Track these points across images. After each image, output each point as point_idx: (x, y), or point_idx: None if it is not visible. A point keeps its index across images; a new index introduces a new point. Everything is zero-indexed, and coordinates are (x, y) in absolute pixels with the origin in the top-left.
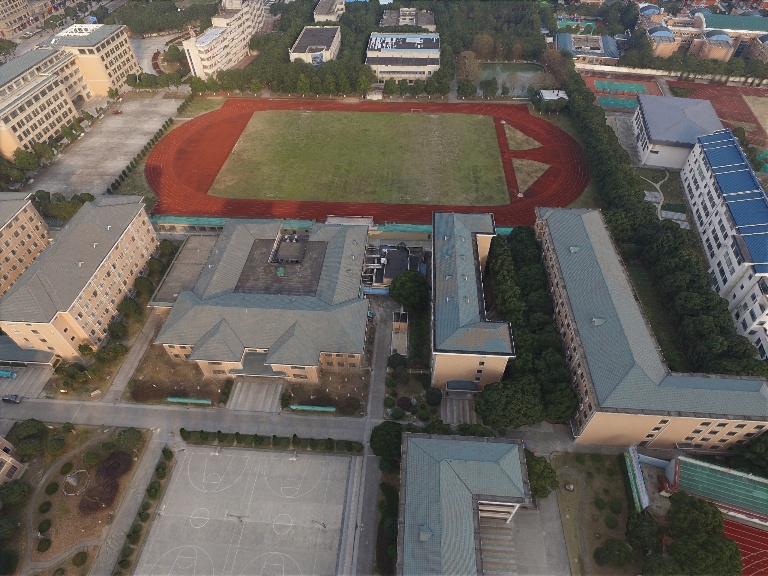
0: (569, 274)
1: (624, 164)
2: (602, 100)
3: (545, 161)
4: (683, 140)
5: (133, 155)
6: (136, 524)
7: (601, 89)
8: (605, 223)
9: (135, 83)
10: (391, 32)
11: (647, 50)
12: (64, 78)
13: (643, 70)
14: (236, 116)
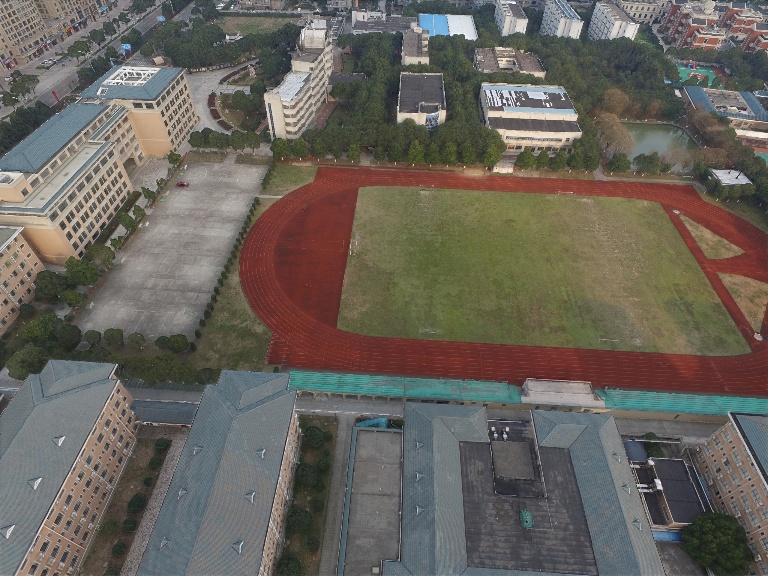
0: None
1: None
2: None
3: (761, 278)
4: None
5: (219, 256)
6: None
7: None
8: None
9: (201, 143)
10: (502, 82)
11: None
12: (115, 141)
13: None
14: (337, 194)
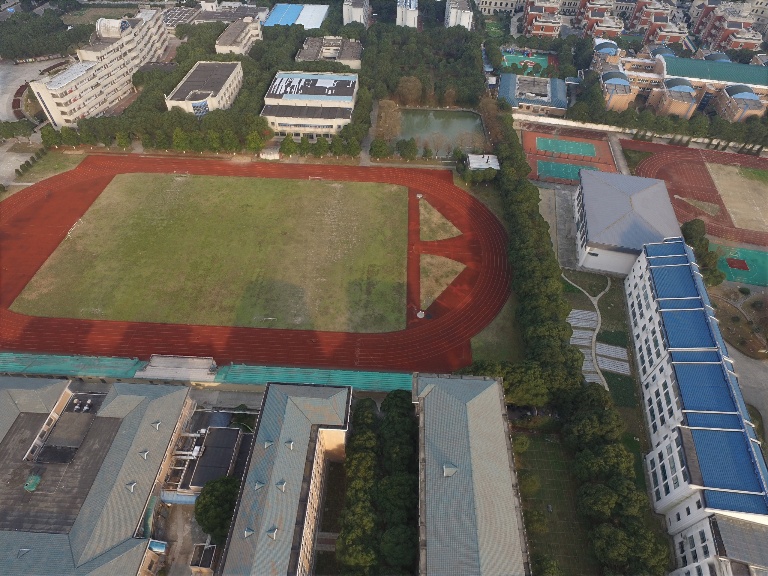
0: (434, 519)
1: (550, 281)
2: (542, 166)
3: (461, 259)
4: (627, 244)
5: None
6: None
7: (543, 150)
8: (504, 406)
9: None
10: (303, 70)
11: (598, 102)
12: None
13: (594, 125)
14: (90, 181)
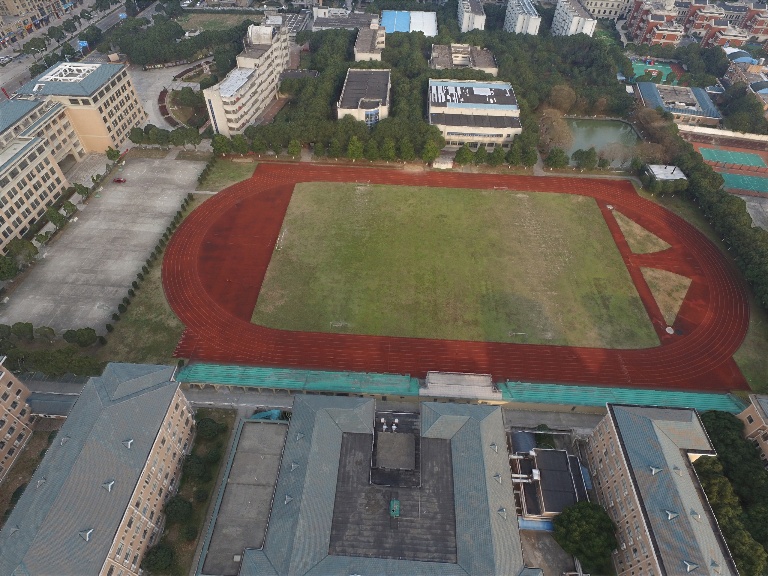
0: None
1: None
2: None
3: (683, 272)
4: None
5: (144, 251)
6: None
7: (711, 160)
8: None
9: (141, 140)
10: (451, 78)
11: (758, 112)
12: (50, 137)
13: (752, 135)
14: (273, 190)
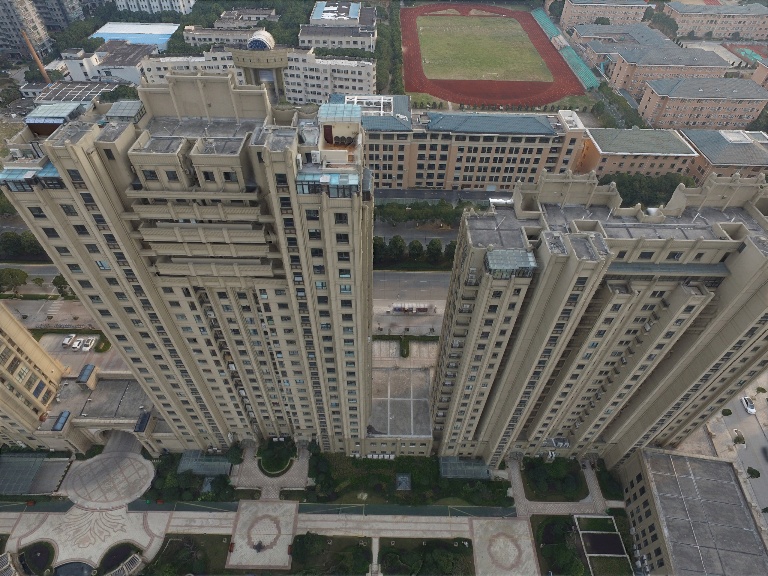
0: None
1: None
2: None
3: (470, 9)
4: None
5: None
6: (735, 68)
7: None
8: None
9: None
10: None
11: None
12: None
13: None
14: (439, 85)
